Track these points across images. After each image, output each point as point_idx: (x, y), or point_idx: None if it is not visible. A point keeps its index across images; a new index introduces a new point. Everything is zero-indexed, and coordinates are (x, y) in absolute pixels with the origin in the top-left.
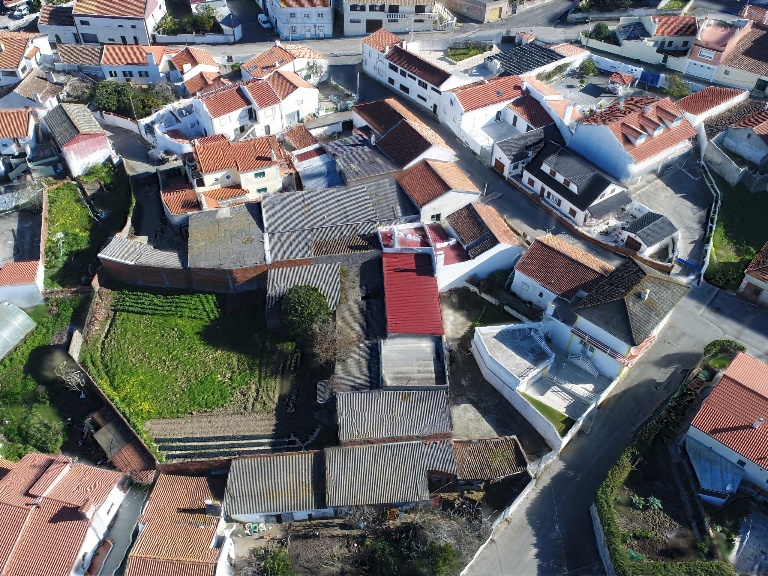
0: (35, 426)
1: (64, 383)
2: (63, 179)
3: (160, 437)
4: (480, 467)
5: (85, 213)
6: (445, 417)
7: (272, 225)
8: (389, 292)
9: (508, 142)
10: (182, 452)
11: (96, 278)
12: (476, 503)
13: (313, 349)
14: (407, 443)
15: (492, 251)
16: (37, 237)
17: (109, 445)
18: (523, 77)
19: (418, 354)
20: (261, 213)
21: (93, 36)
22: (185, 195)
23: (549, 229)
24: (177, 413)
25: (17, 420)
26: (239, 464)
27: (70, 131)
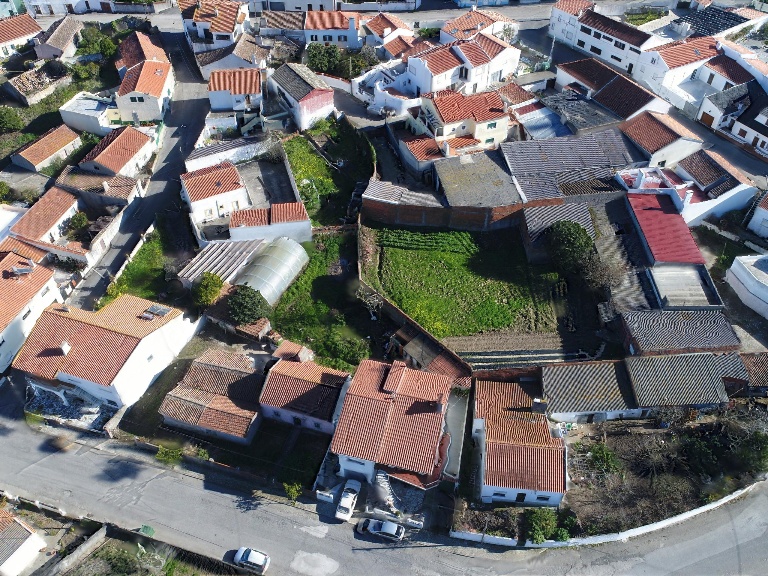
0: (340, 343)
1: (365, 304)
2: (292, 133)
3: (460, 351)
4: (766, 376)
5: (322, 162)
6: (729, 332)
7: (517, 169)
8: (644, 227)
9: (717, 96)
10: (484, 364)
11: (360, 217)
12: (766, 407)
13: (585, 276)
14: (698, 354)
15: (733, 191)
16: (284, 183)
17: (420, 357)
18: (715, 38)
19: (685, 280)
20: (503, 159)
21: (281, 4)
22: (427, 143)
23: (767, 175)
24: (468, 332)
25: (321, 338)
26: (549, 371)
27: (303, 87)
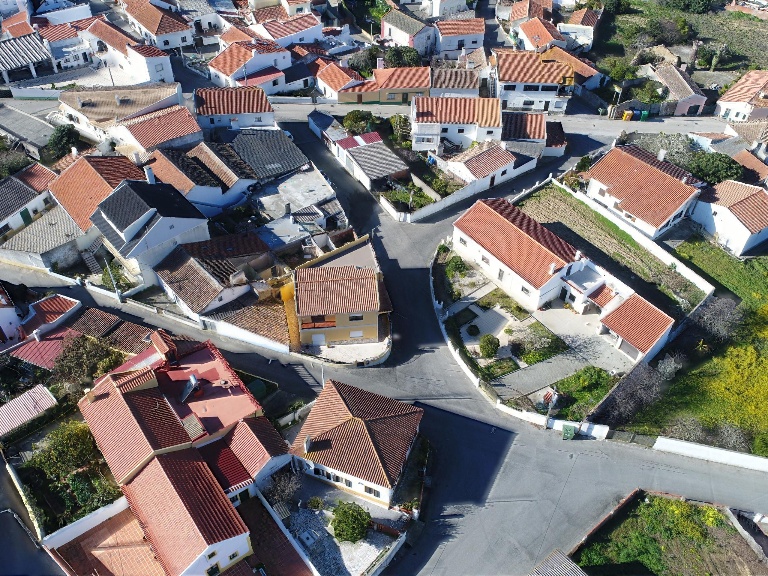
0: None
1: None
2: None
3: None
4: None
5: None
6: None
7: None
8: None
9: (79, 6)
10: None
11: None
12: None
13: None
14: None
15: None
16: None
17: None
18: None
19: None
20: None
21: None
22: None
23: None
24: None
25: None
26: None
27: (405, 13)
